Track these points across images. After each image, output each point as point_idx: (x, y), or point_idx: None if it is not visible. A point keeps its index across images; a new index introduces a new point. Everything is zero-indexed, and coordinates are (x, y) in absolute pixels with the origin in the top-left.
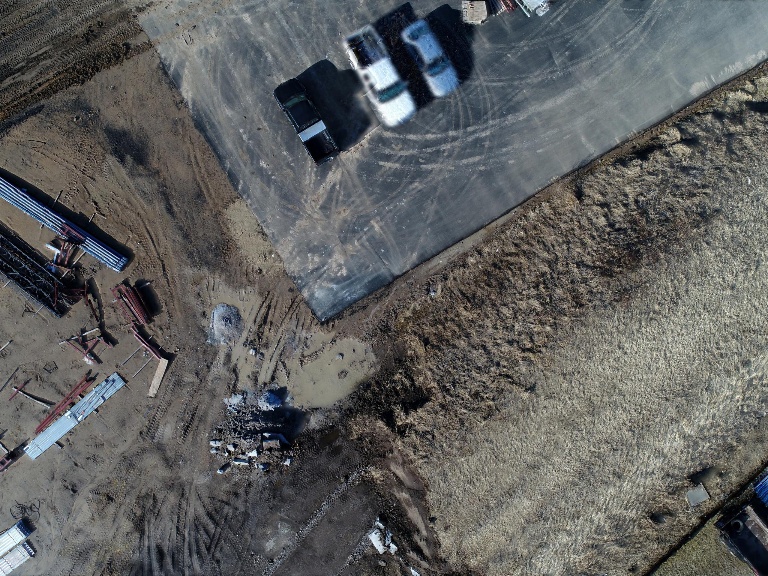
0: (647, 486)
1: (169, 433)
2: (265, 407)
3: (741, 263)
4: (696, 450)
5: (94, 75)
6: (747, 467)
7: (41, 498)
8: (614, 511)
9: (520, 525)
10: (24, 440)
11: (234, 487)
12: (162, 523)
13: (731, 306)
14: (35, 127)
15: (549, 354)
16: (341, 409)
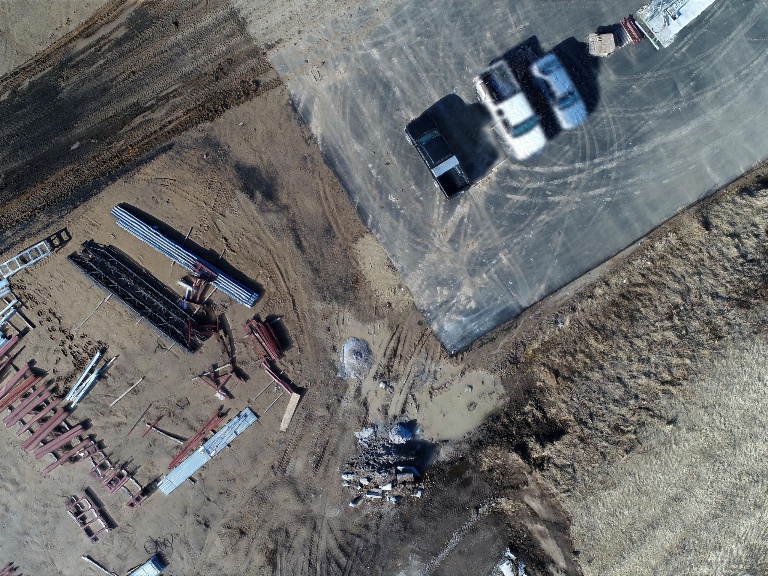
0: None
1: (300, 467)
2: (397, 440)
3: None
4: None
5: (223, 112)
6: None
7: (175, 533)
8: (752, 541)
9: (663, 557)
10: (157, 476)
11: (365, 520)
12: (294, 556)
13: None
14: (165, 165)
15: (690, 387)
16: (471, 441)
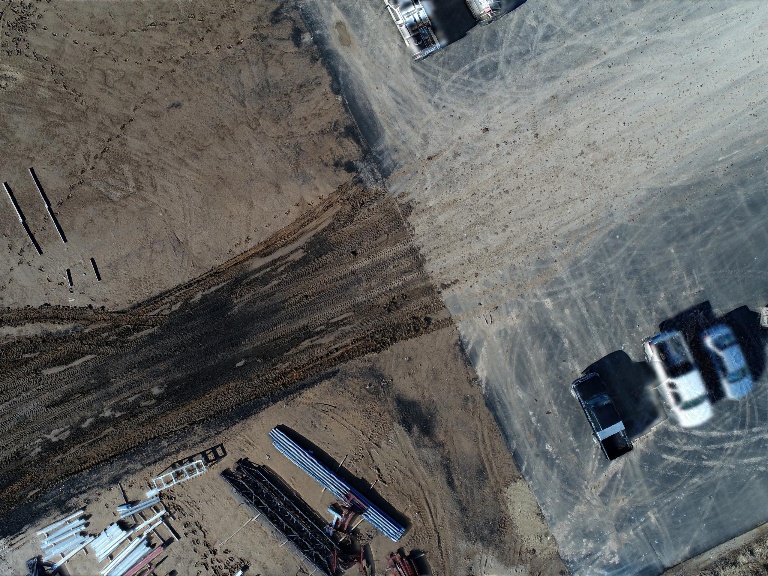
0: None
1: None
2: None
3: None
4: None
5: (391, 345)
6: None
7: None
8: None
9: None
10: None
11: None
12: None
13: None
14: (328, 391)
15: None
16: None
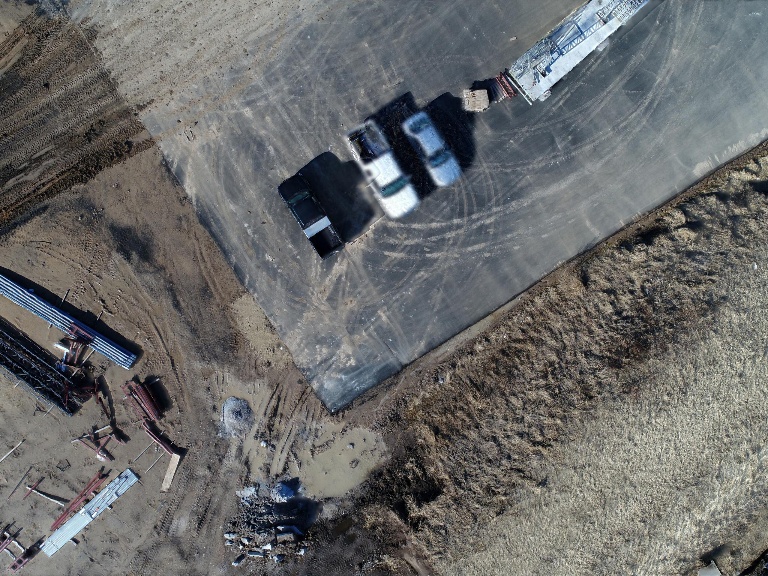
0: (659, 571)
1: (183, 526)
2: (278, 499)
3: (749, 349)
4: (707, 532)
5: (97, 174)
6: (758, 544)
7: None
8: None
9: None
10: (39, 537)
11: None
12: None
13: (740, 393)
14: (40, 227)
15: (559, 448)
16: (353, 498)
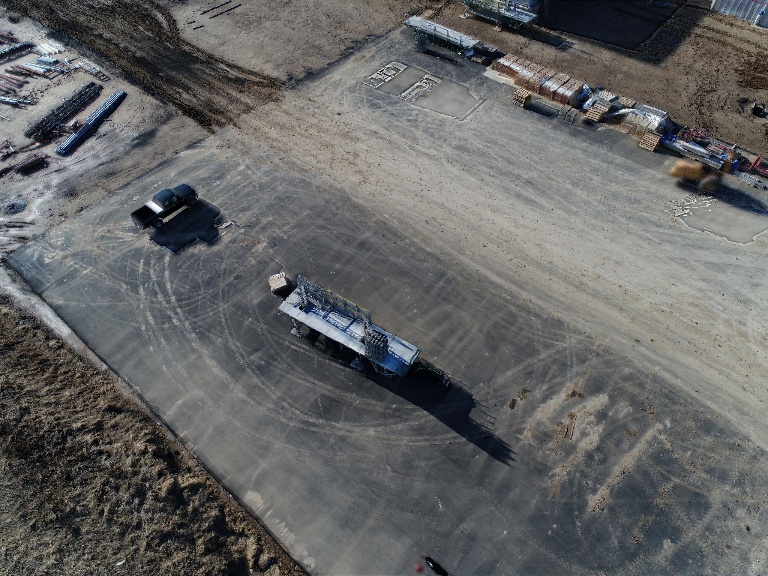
0: None
1: None
2: None
3: None
4: None
5: (189, 118)
6: None
7: None
8: None
9: None
10: None
11: None
12: None
13: None
14: (153, 104)
15: None
16: None
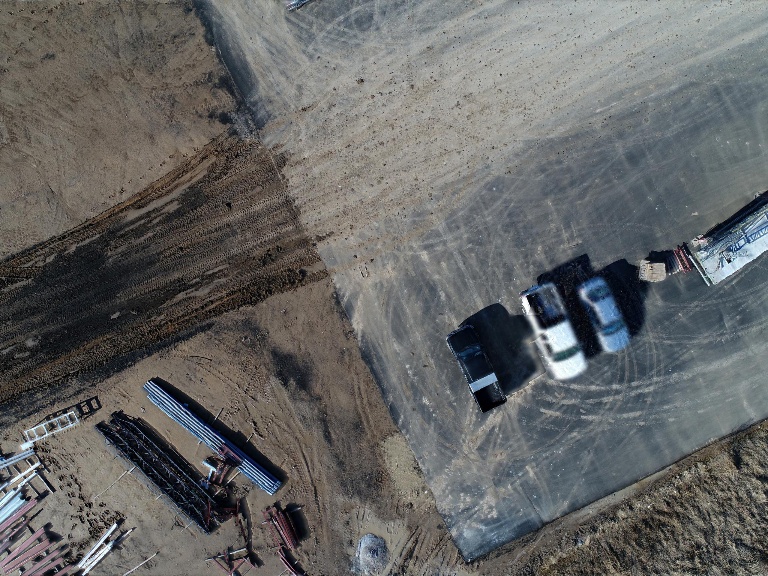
0: None
1: None
2: None
3: None
4: None
5: (267, 298)
6: None
7: None
8: None
9: None
10: None
11: None
12: None
13: None
14: (203, 344)
15: None
16: None
